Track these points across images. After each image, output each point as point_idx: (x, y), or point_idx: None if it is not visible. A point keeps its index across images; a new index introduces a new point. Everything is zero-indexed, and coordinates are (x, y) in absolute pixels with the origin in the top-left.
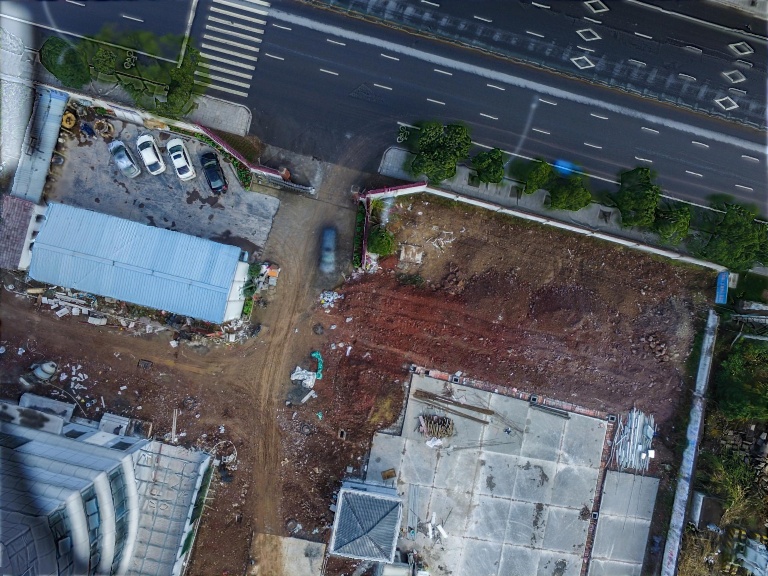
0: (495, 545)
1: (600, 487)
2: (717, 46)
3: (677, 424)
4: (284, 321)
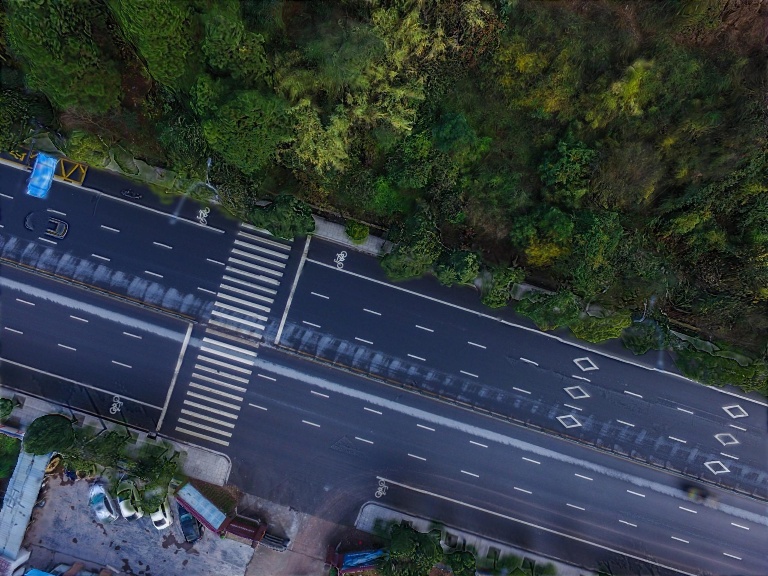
0: None
1: None
2: (710, 408)
3: None
4: None
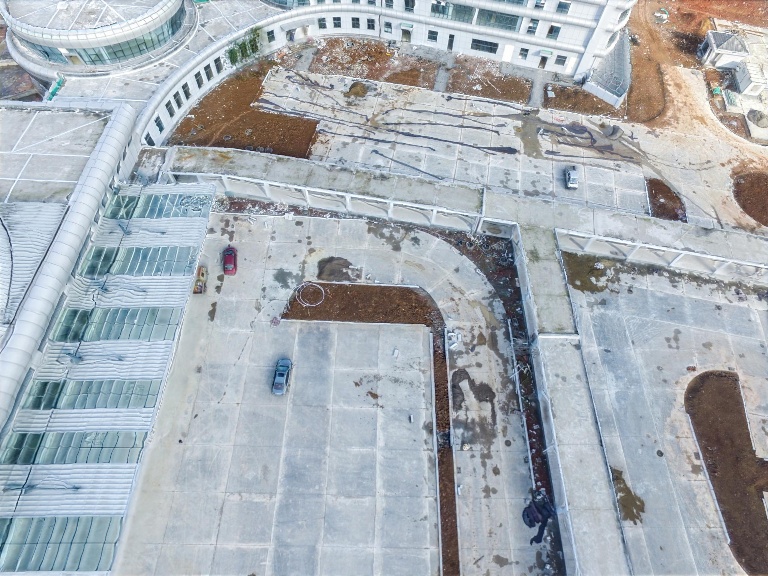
0: None
1: None
2: None
3: None
4: None
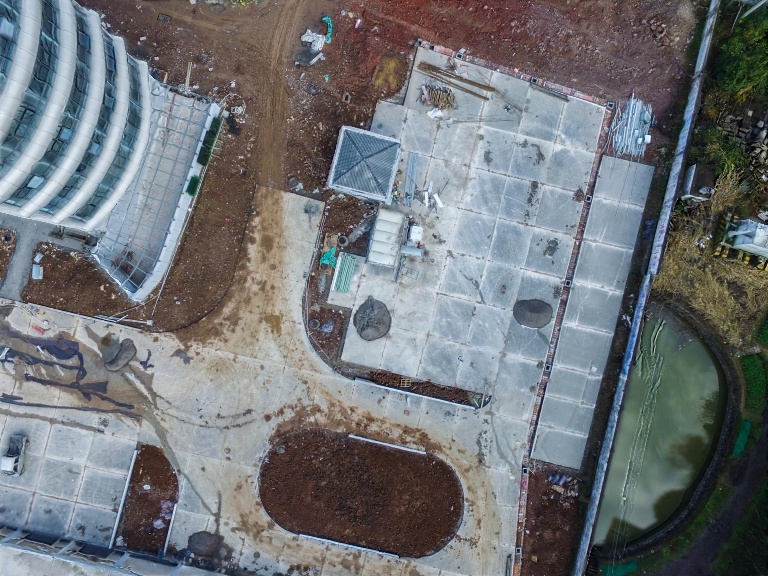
0: (489, 219)
1: (595, 173)
2: None
3: (674, 110)
4: None
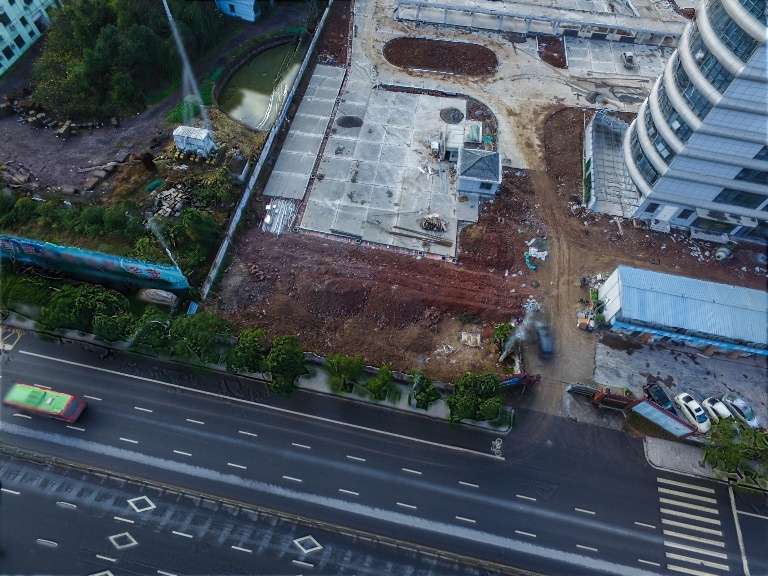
0: (384, 163)
1: (308, 191)
2: None
3: (246, 224)
4: (563, 290)
